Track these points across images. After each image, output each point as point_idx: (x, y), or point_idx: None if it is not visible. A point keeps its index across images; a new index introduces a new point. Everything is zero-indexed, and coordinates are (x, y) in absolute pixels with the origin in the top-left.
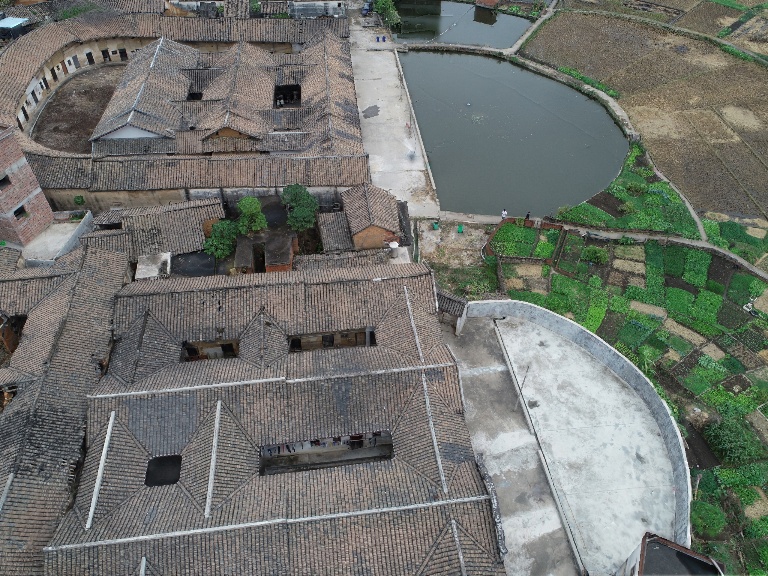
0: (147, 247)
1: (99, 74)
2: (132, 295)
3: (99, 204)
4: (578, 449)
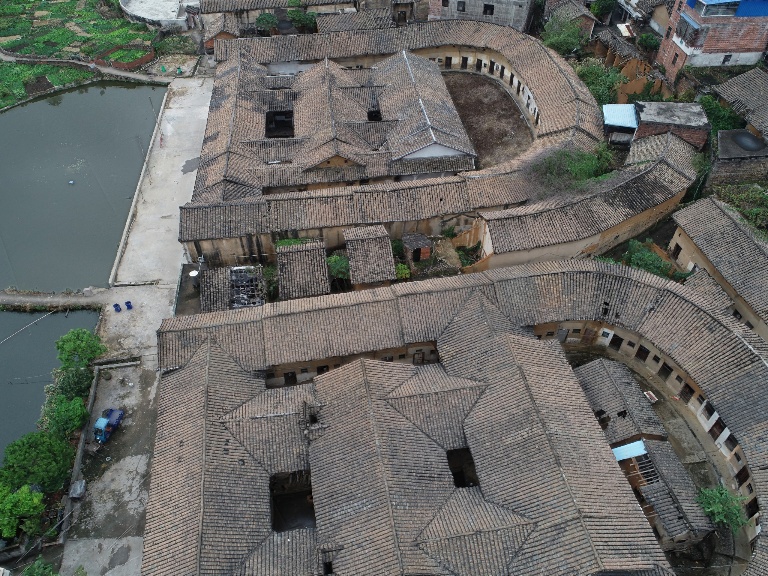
0: None
1: None
2: None
3: None
4: (164, 3)
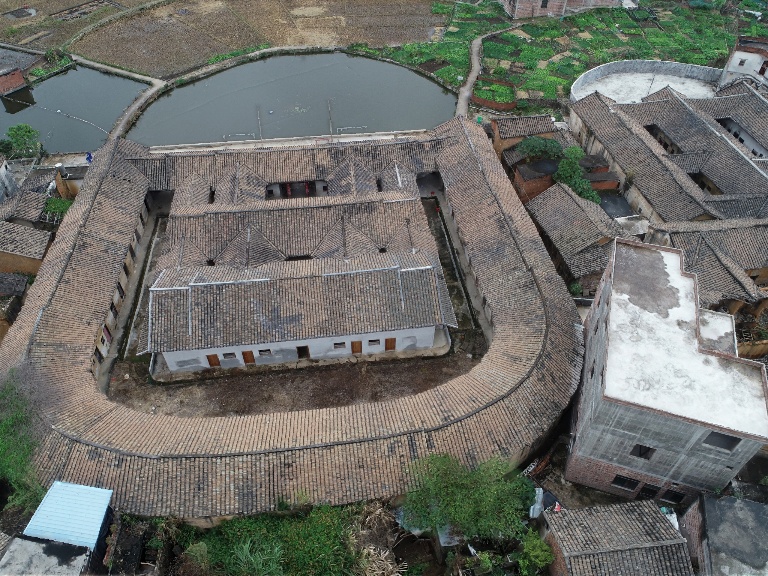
0: None
1: None
2: None
3: None
4: None
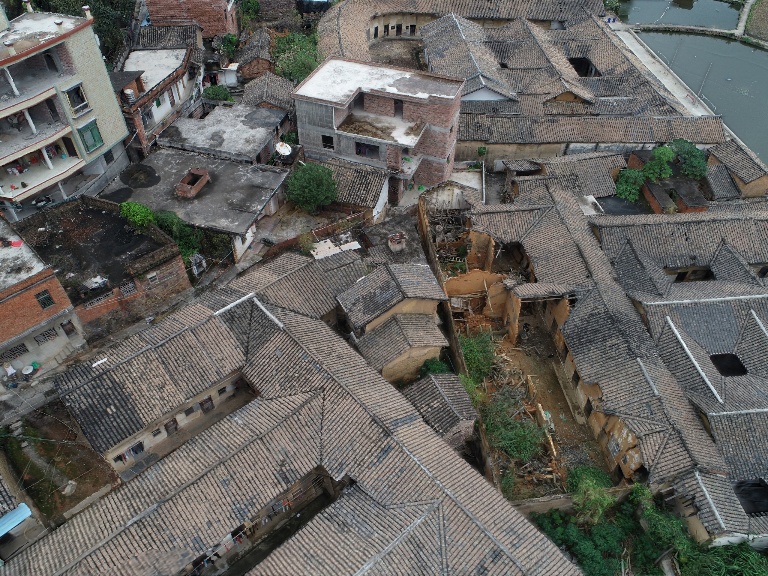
0: (570, 191)
1: (386, 47)
2: (613, 226)
3: (487, 156)
4: None
